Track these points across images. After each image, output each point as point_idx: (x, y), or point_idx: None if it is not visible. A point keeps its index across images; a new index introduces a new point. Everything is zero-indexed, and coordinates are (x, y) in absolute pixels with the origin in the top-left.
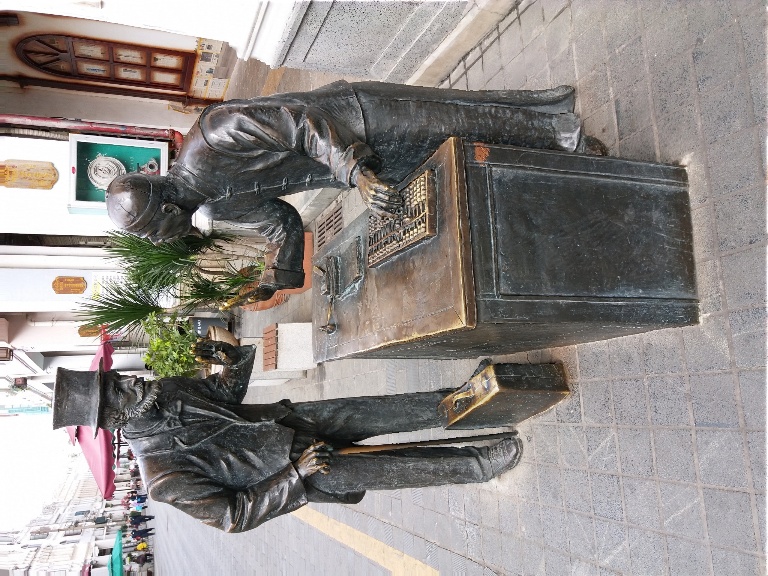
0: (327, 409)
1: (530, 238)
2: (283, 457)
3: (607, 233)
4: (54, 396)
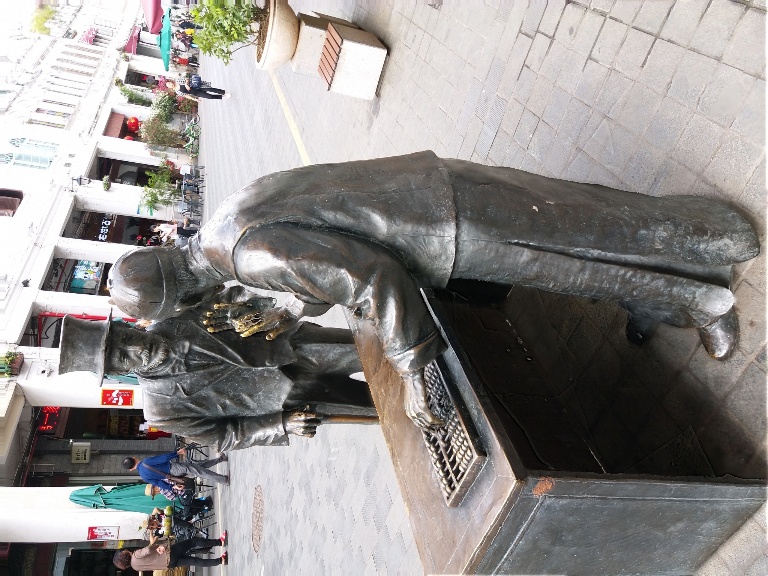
0: (334, 351)
1: (549, 550)
2: (277, 404)
3: (638, 541)
4: (59, 365)
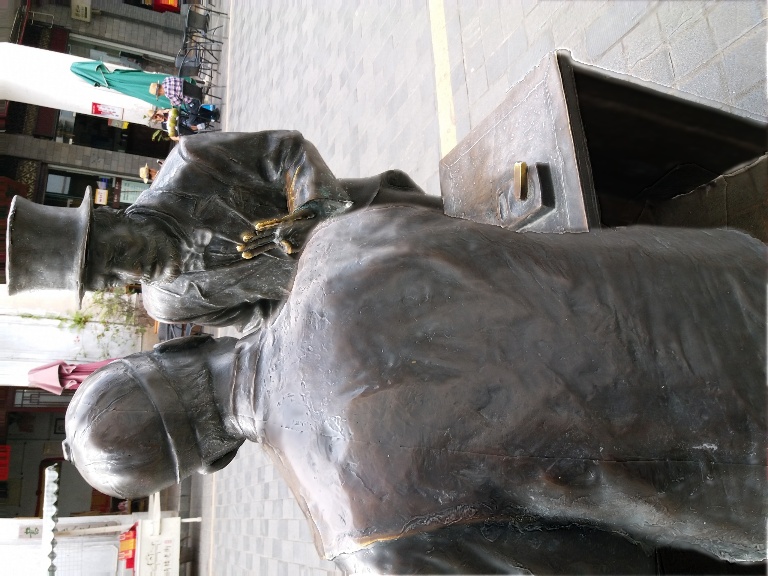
0: None
1: None
2: None
3: None
4: None
